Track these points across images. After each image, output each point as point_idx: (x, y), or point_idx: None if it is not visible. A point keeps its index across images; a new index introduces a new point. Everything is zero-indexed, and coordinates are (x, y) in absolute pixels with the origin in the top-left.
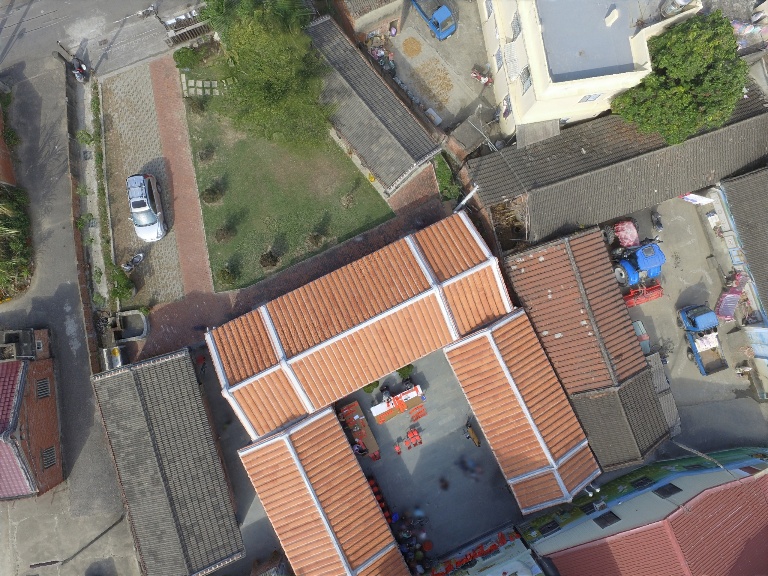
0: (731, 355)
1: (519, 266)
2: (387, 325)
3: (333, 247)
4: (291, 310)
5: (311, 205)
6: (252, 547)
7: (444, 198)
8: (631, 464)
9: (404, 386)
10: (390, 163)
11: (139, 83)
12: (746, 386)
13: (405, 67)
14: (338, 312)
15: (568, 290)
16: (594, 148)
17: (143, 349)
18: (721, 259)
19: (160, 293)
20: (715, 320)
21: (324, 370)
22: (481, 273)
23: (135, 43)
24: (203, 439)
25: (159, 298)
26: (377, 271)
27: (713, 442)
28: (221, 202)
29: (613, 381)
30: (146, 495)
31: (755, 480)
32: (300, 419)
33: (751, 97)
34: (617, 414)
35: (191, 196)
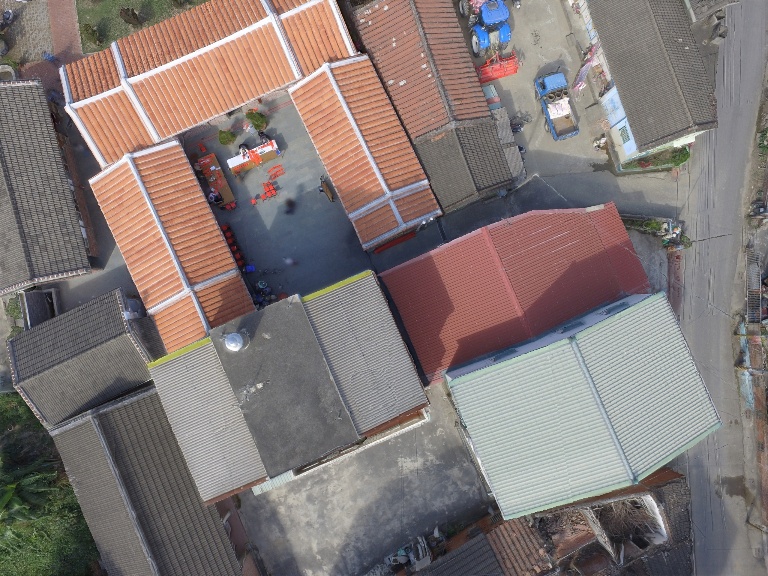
0: (589, 130)
1: (367, 18)
2: (227, 54)
3: None
4: (139, 44)
5: None
6: None
7: None
8: (468, 200)
9: None
10: None
11: None
12: (604, 160)
13: None
14: (181, 43)
15: (410, 35)
16: None
17: None
18: (579, 35)
19: (31, 53)
20: (563, 80)
21: (167, 97)
22: (319, 8)
23: None
24: (52, 162)
25: (30, 57)
26: (222, 9)
27: None
28: None
29: (449, 117)
30: None
31: (586, 212)
32: None
33: None
34: (455, 153)
35: None
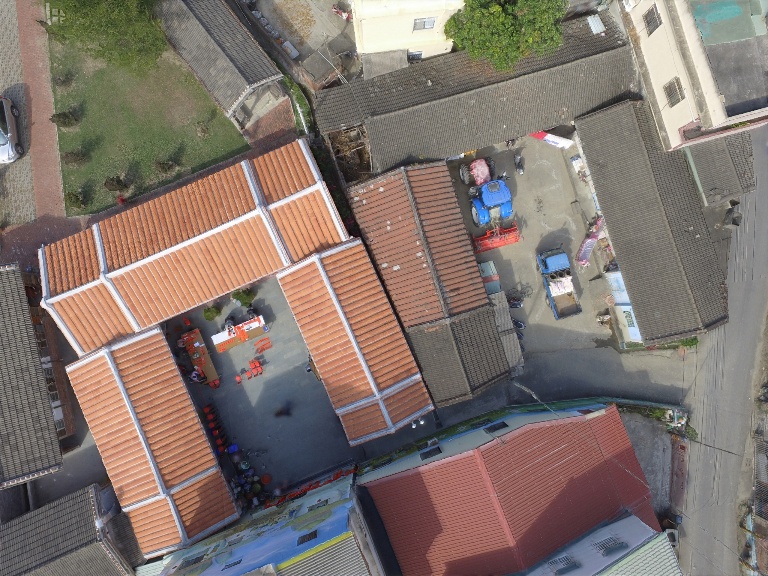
0: (592, 303)
1: (361, 197)
2: (212, 245)
3: (186, 177)
4: (121, 228)
5: (167, 135)
6: (89, 470)
7: (301, 132)
8: (461, 399)
9: None
10: (227, 86)
11: (5, 11)
12: (607, 335)
13: (268, 2)
14: (165, 231)
15: (405, 221)
16: (441, 80)
17: None
18: (585, 204)
19: (12, 215)
20: (566, 262)
21: (148, 288)
22: (310, 197)
23: None
24: (27, 352)
25: (11, 220)
26: (209, 193)
27: (568, 390)
28: (77, 128)
29: (444, 313)
30: None
31: (586, 420)
32: None
33: (608, 35)
34: (449, 348)
35: (48, 122)
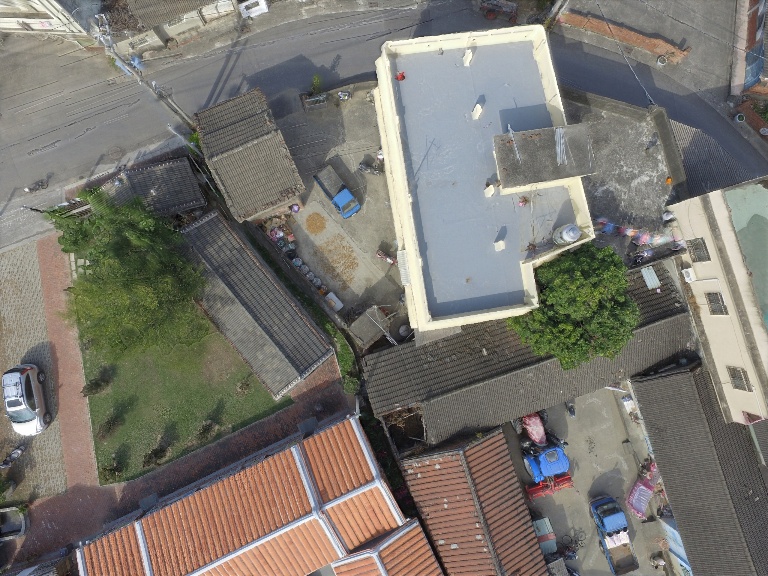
0: (646, 545)
1: (415, 471)
2: (266, 549)
3: (227, 436)
4: (167, 528)
5: (205, 391)
6: None
7: None
8: None
9: None
10: (275, 372)
11: (25, 262)
12: None
13: (308, 244)
14: (215, 534)
15: (464, 502)
16: (496, 349)
17: (22, 546)
18: (637, 446)
19: (41, 486)
20: (624, 521)
21: None
22: (367, 493)
23: (22, 219)
24: None
25: (40, 492)
26: (259, 487)
27: None
28: (109, 389)
29: None
30: None
31: None
32: None
33: (664, 292)
34: None
35: (77, 383)
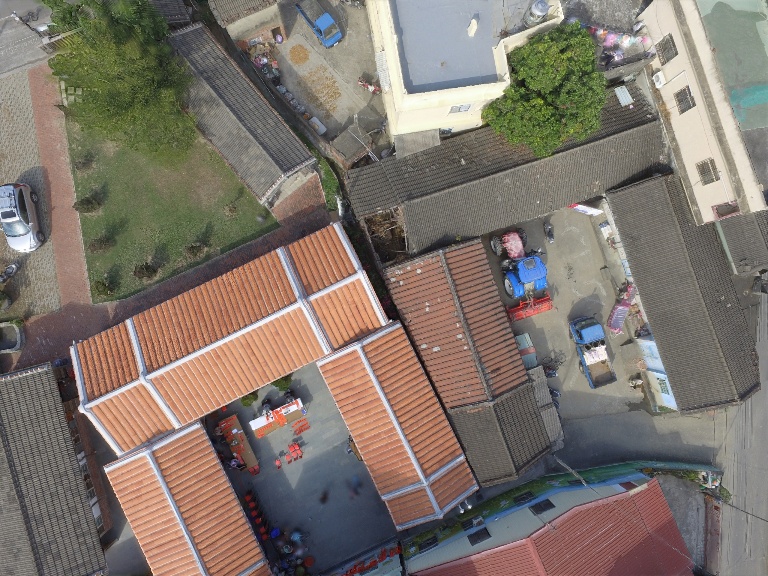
0: (624, 367)
1: (398, 278)
2: (253, 339)
3: (215, 258)
4: (157, 323)
5: (193, 215)
6: (128, 563)
7: None
8: (507, 480)
9: (286, 399)
10: (260, 174)
11: (17, 90)
12: (639, 399)
13: (292, 75)
14: (203, 326)
15: (444, 303)
16: (474, 159)
17: (18, 361)
18: (614, 270)
19: (36, 304)
20: (601, 333)
21: (188, 385)
22: (350, 286)
23: (14, 49)
24: (64, 455)
25: (35, 309)
26: (246, 284)
27: (604, 456)
28: (100, 212)
29: (487, 396)
30: (3, 512)
31: (630, 496)
32: (168, 434)
33: (636, 107)
34: (493, 429)
35: (69, 206)
